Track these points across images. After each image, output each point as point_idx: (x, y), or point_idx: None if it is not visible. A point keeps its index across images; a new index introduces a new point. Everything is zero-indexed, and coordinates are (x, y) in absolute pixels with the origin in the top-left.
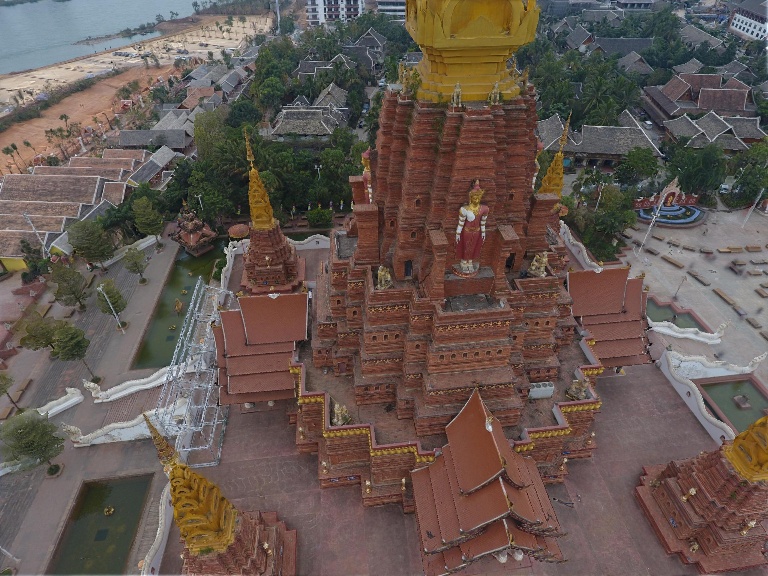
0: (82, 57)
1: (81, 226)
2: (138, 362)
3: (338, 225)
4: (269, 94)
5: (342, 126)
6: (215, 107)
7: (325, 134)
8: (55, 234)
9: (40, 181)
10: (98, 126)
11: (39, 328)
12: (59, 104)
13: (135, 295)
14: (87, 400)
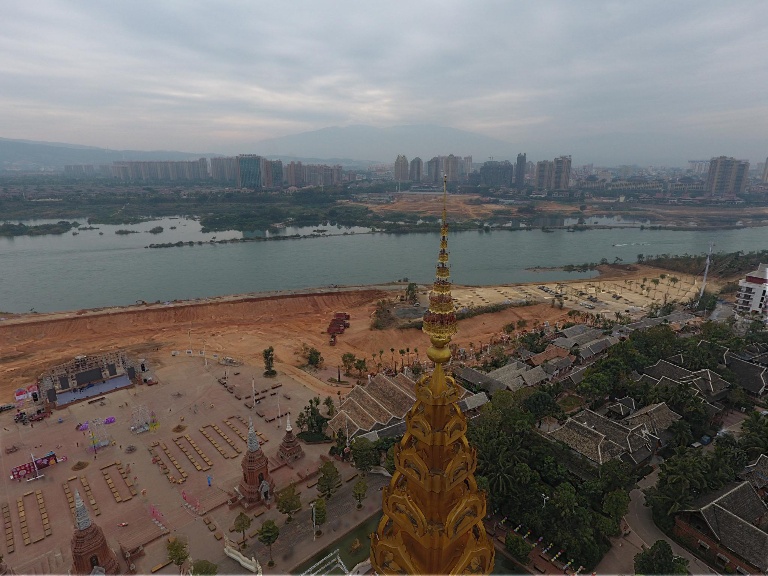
0: (517, 284)
1: (361, 443)
2: (299, 570)
3: (533, 566)
4: (587, 389)
5: (639, 455)
6: (558, 370)
7: (595, 461)
8: (364, 430)
9: (390, 387)
10: (470, 350)
11: (286, 501)
12: (471, 318)
13: (346, 514)
14: (256, 574)
